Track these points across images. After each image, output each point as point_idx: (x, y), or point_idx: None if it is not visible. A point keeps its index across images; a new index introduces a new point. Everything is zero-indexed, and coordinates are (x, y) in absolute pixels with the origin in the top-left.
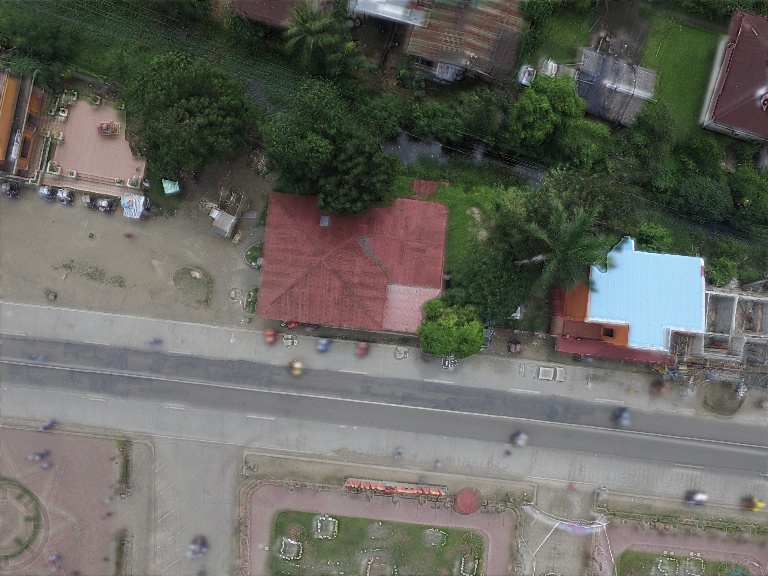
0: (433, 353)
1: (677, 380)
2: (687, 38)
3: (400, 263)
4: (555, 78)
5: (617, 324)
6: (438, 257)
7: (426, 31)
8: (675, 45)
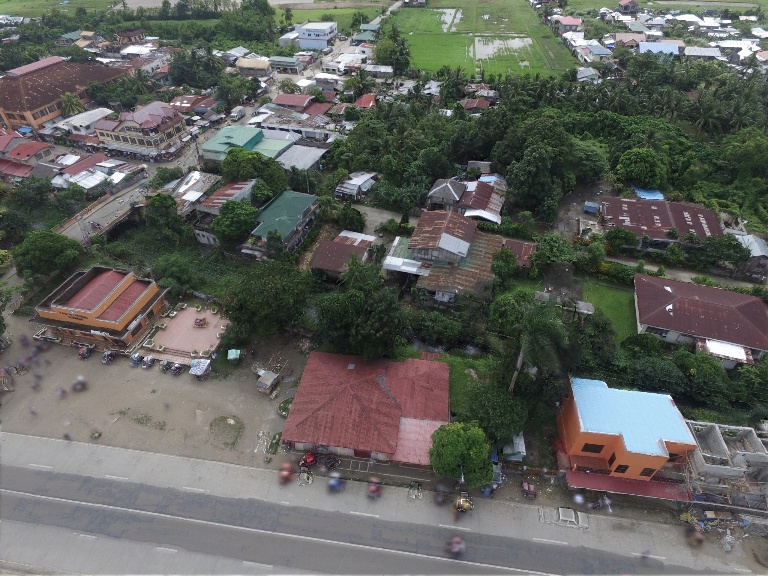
0: None
1: (713, 533)
2: (604, 291)
3: (412, 398)
4: None
5: (611, 435)
6: (444, 397)
7: (427, 277)
8: (597, 294)
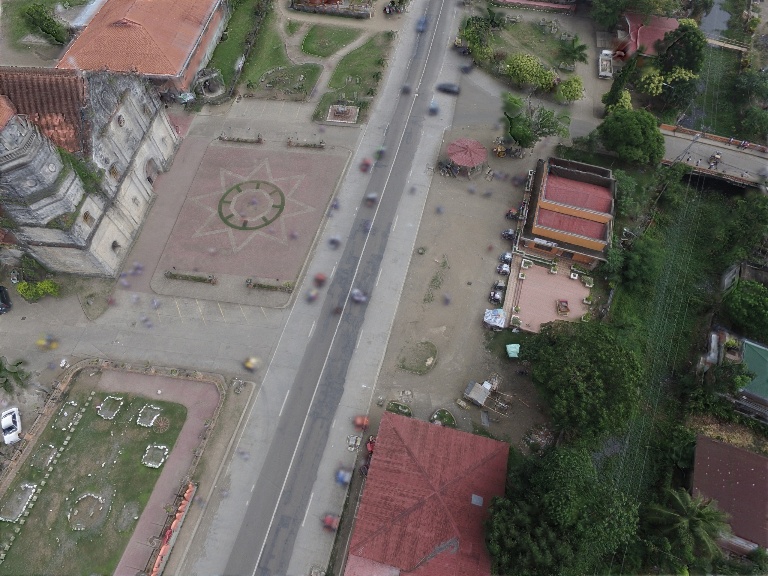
0: None
1: None
2: None
3: None
4: None
5: None
6: None
7: None
8: None
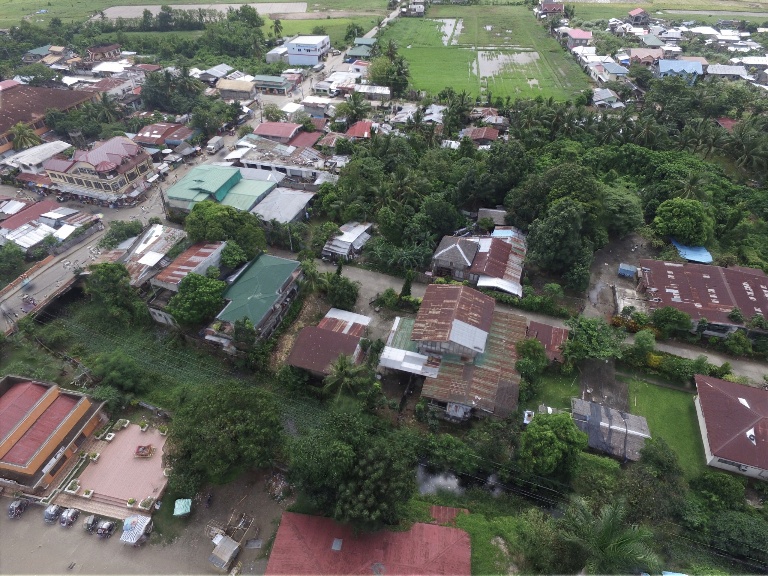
0: None
1: None
2: (656, 392)
3: None
4: None
5: None
6: None
7: (436, 380)
8: (648, 397)
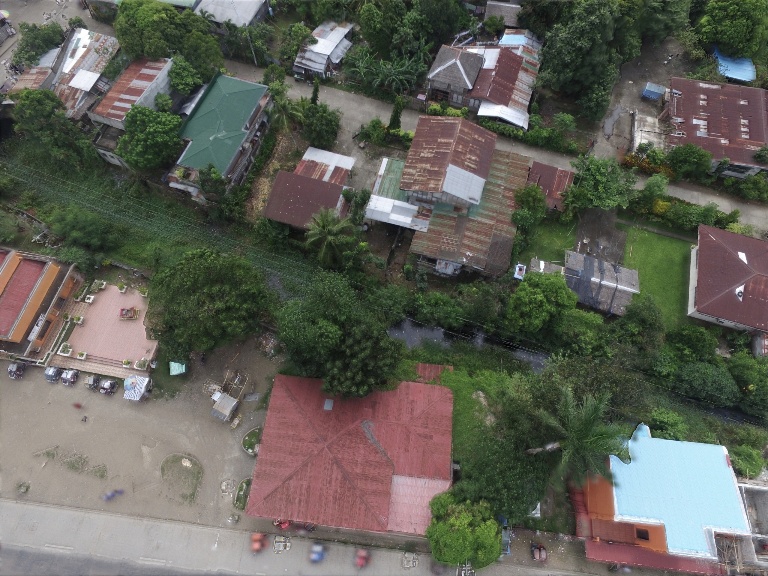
0: (447, 561)
1: None
2: (654, 241)
3: (407, 450)
4: (544, 273)
5: (651, 524)
6: (447, 444)
7: (426, 235)
8: (645, 247)
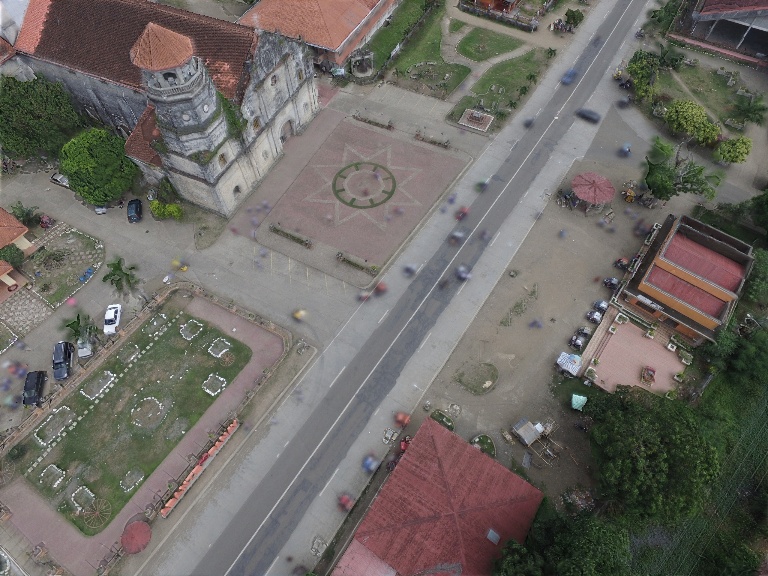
0: None
1: None
2: None
3: None
4: None
5: None
6: None
7: None
8: None
